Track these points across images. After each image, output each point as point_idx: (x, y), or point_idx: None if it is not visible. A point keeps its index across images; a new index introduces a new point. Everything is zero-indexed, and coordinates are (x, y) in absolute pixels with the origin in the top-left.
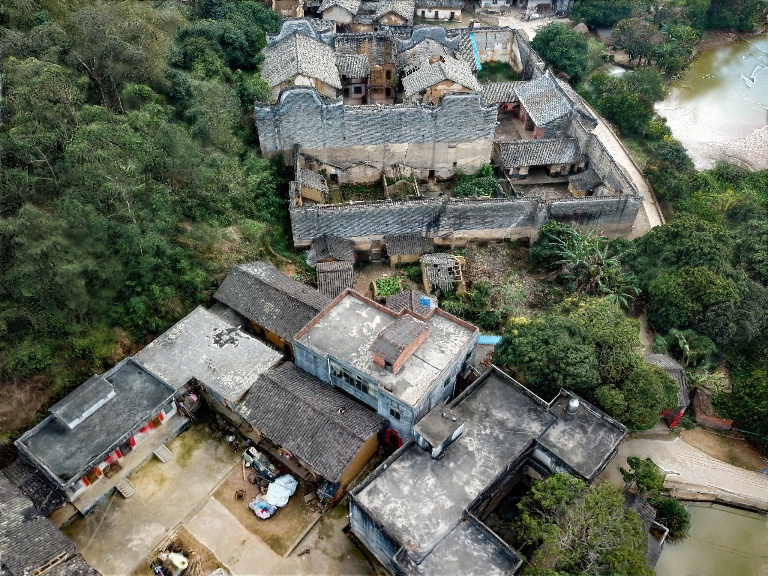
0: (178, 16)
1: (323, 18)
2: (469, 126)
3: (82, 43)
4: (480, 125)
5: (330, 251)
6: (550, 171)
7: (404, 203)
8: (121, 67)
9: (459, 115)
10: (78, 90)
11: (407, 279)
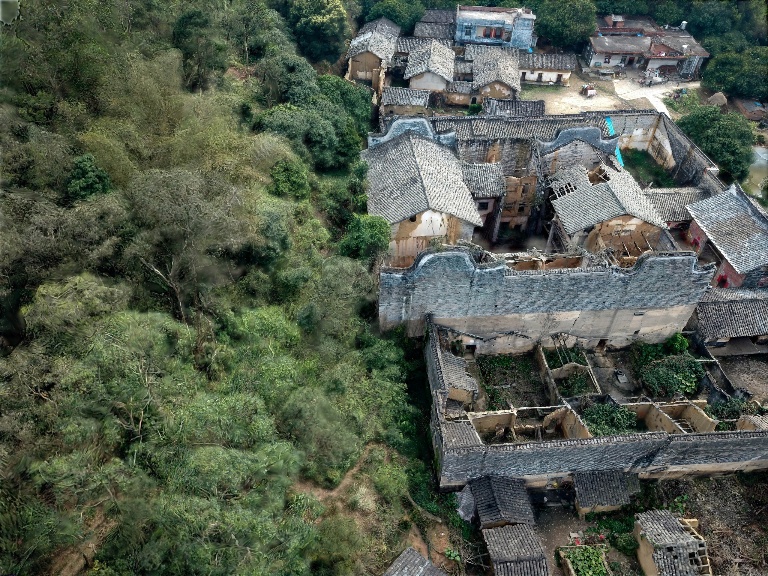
0: (279, 148)
1: (410, 85)
2: (669, 291)
3: (152, 228)
4: (685, 290)
5: (501, 509)
6: (758, 337)
7: (613, 440)
8: (204, 246)
9: (660, 279)
10: (139, 285)
11: (610, 547)
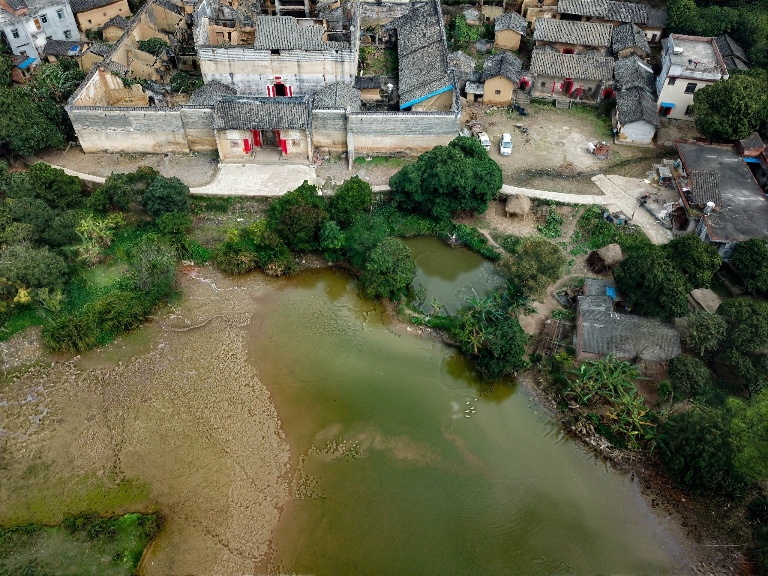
0: None
1: None
2: None
3: None
4: None
5: None
6: None
7: None
8: None
9: None
10: None
11: None
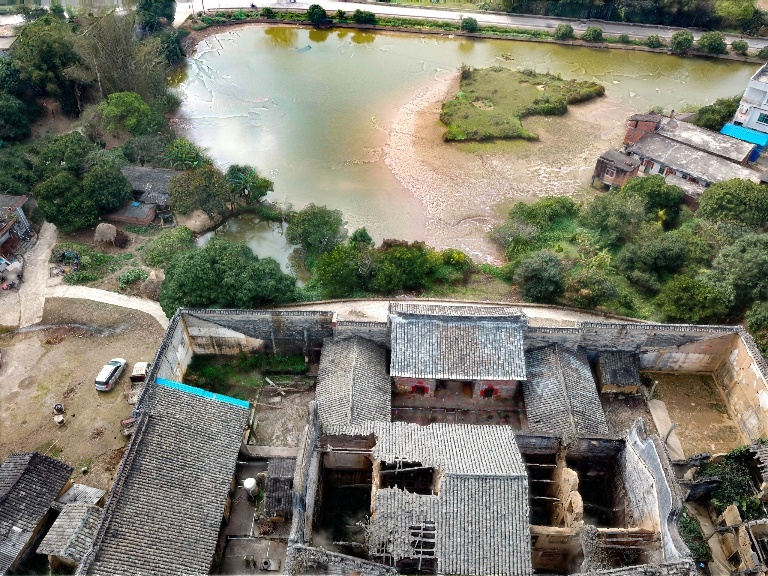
0: None
1: None
2: None
3: None
4: None
5: None
6: None
7: None
8: None
9: None
10: None
11: None
